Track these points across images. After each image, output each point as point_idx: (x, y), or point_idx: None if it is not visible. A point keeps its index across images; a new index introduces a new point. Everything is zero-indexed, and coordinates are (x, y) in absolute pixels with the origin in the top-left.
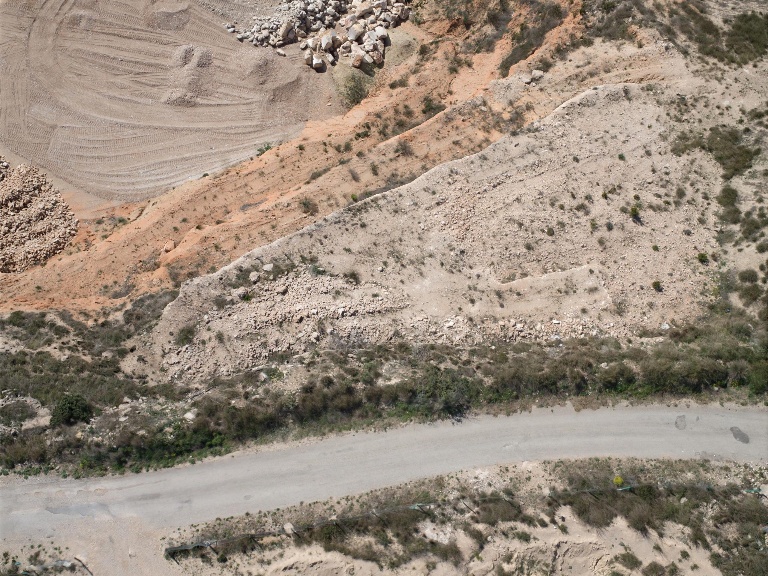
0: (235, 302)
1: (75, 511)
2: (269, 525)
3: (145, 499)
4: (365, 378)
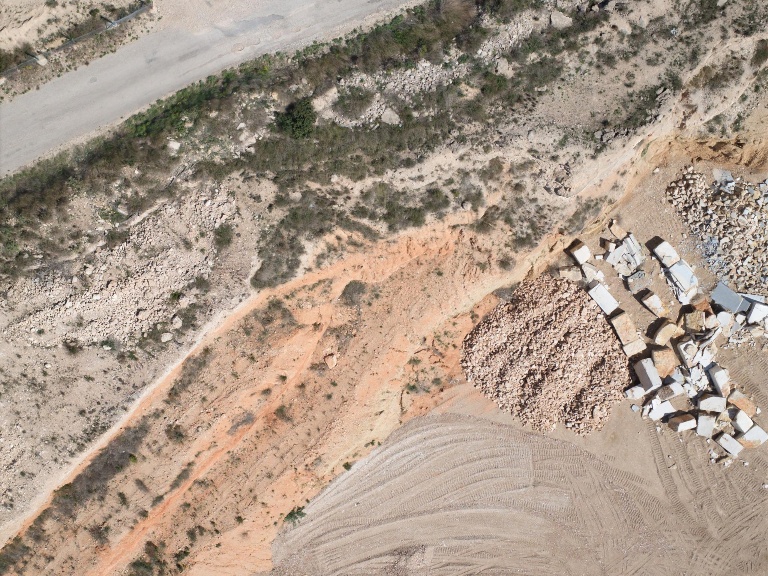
0: (188, 289)
1: (255, 22)
2: (62, 58)
3: (192, 52)
4: (6, 229)
